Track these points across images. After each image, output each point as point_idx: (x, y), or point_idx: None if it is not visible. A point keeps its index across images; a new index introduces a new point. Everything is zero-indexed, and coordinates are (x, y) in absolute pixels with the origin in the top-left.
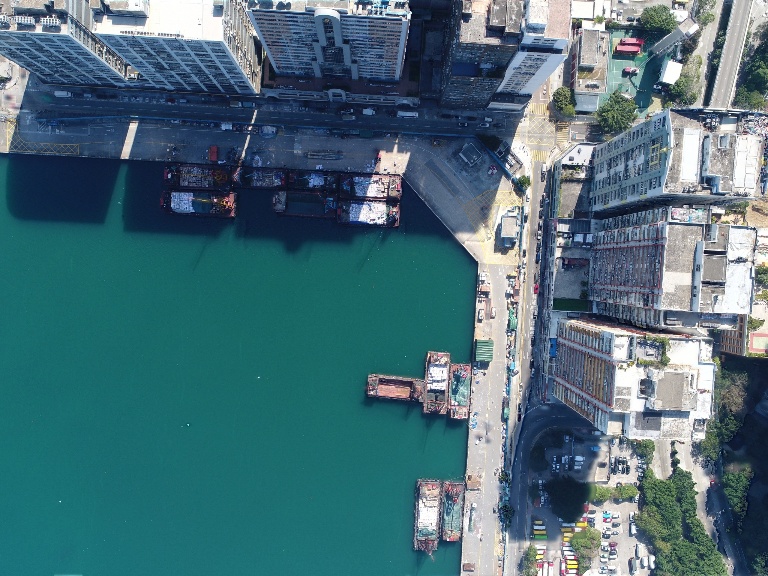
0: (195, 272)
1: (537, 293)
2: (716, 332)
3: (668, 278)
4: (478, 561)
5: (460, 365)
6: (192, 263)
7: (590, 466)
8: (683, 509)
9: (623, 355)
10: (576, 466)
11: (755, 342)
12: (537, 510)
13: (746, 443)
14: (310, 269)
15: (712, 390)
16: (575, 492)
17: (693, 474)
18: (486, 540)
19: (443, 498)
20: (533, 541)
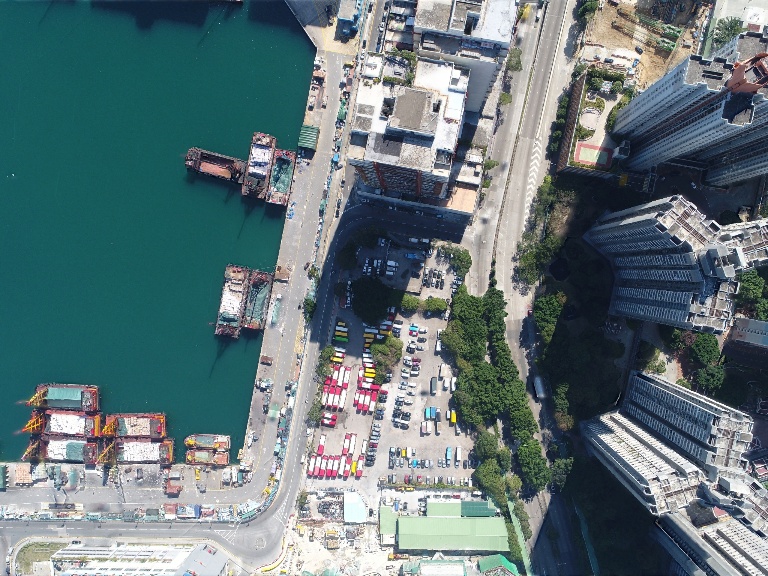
0: (41, 26)
1: None
2: (553, 150)
3: None
4: (277, 356)
5: None
6: (39, 16)
7: (403, 275)
8: (490, 329)
9: (374, 75)
10: (388, 271)
11: (582, 153)
12: (343, 312)
13: (569, 272)
14: (151, 36)
15: (459, 120)
16: (377, 292)
17: (511, 300)
18: (288, 335)
19: (251, 286)
20: (334, 343)
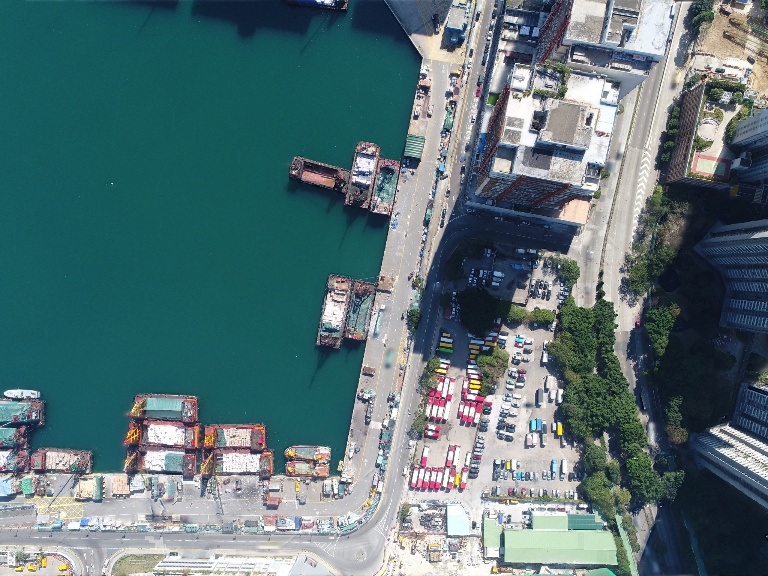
0: (141, 33)
1: (479, 96)
2: (663, 160)
3: (580, 6)
4: (379, 367)
5: (389, 160)
6: (139, 24)
7: (509, 286)
8: (600, 341)
9: (522, 87)
10: (494, 282)
11: (699, 164)
12: (447, 323)
13: (679, 283)
14: (253, 44)
15: (611, 133)
16: (486, 303)
17: (618, 311)
18: (390, 346)
19: (353, 296)
20: (438, 354)
